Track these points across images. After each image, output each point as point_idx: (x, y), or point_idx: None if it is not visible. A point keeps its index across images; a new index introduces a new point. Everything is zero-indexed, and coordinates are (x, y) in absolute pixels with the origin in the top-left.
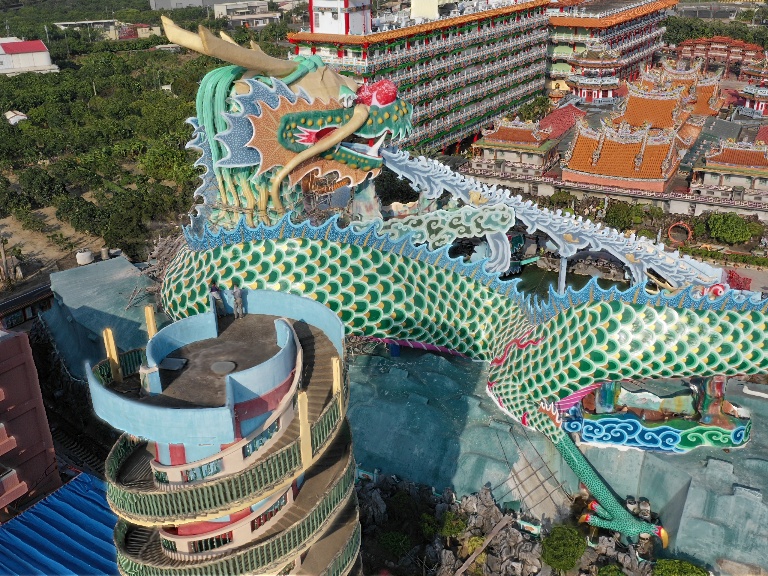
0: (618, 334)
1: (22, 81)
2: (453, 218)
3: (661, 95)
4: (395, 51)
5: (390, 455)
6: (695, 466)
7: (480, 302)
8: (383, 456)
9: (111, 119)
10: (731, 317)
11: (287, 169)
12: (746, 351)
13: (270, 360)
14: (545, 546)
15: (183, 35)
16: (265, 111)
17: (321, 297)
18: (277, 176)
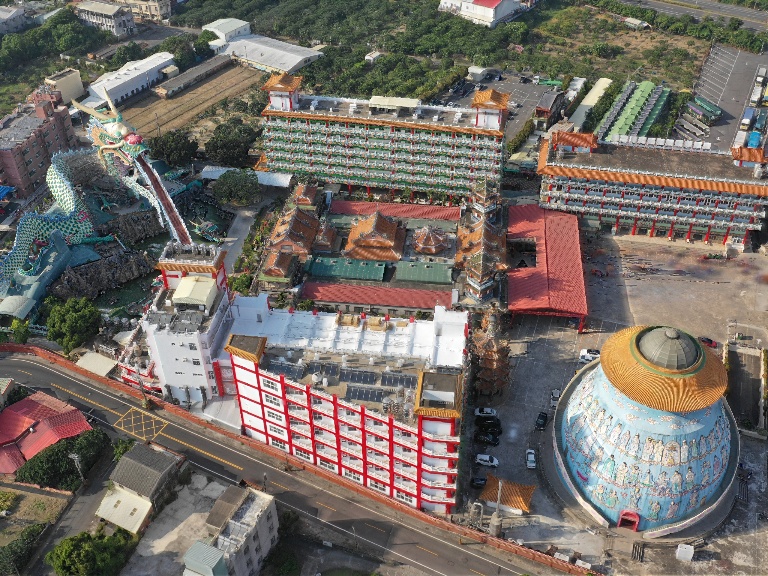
0: None
1: None
2: None
3: None
4: (295, 122)
5: None
6: None
7: None
8: None
9: None
10: None
11: None
12: None
13: None
14: None
15: None
16: (96, 128)
17: None
18: None
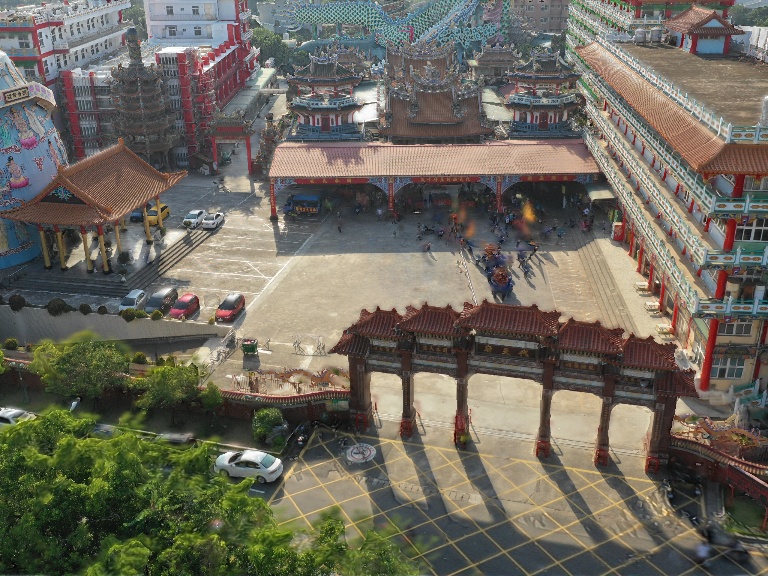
0: None
1: None
2: None
3: (420, 55)
4: None
5: None
6: None
7: None
8: None
9: None
10: None
11: None
12: None
13: None
14: None
15: None
16: None
17: None
18: None
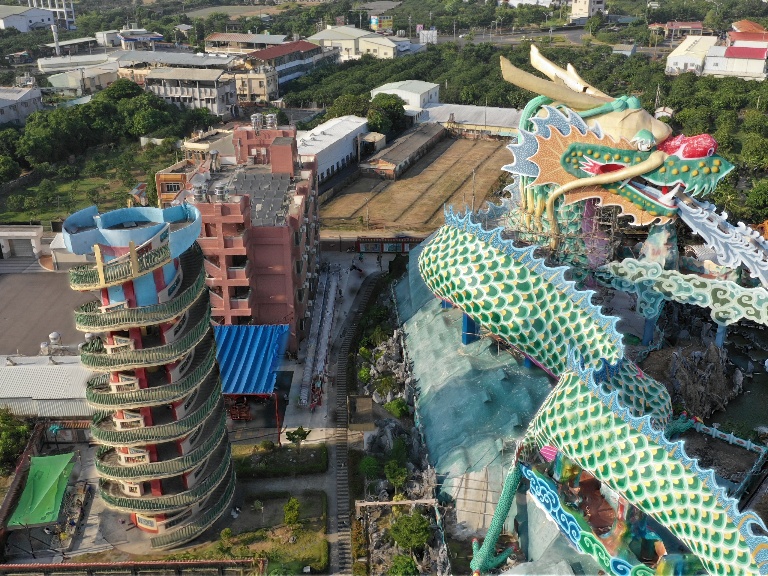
0: (560, 405)
1: (719, 83)
2: (743, 295)
3: None
4: None
5: (435, 420)
6: (555, 558)
7: (600, 354)
8: (432, 418)
9: (743, 133)
10: (639, 441)
11: (562, 189)
12: (634, 481)
13: (119, 231)
14: (399, 518)
15: (541, 62)
16: (554, 135)
17: (462, 284)
18: (553, 192)
